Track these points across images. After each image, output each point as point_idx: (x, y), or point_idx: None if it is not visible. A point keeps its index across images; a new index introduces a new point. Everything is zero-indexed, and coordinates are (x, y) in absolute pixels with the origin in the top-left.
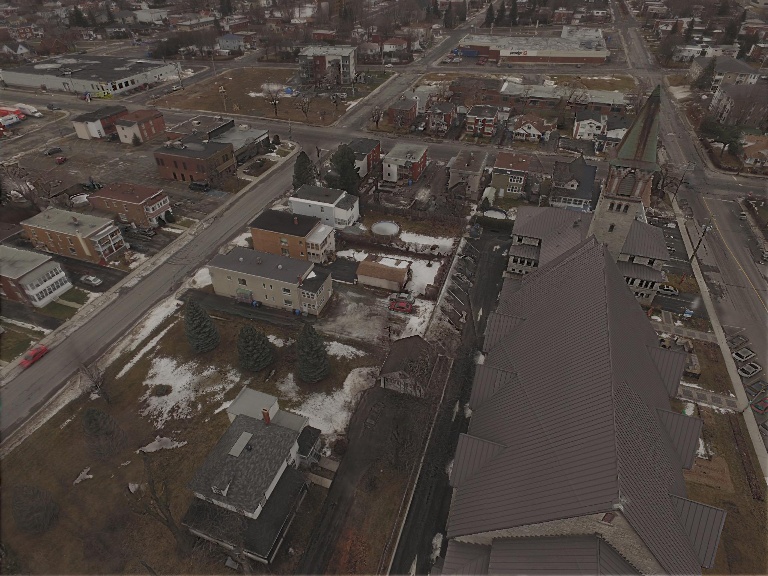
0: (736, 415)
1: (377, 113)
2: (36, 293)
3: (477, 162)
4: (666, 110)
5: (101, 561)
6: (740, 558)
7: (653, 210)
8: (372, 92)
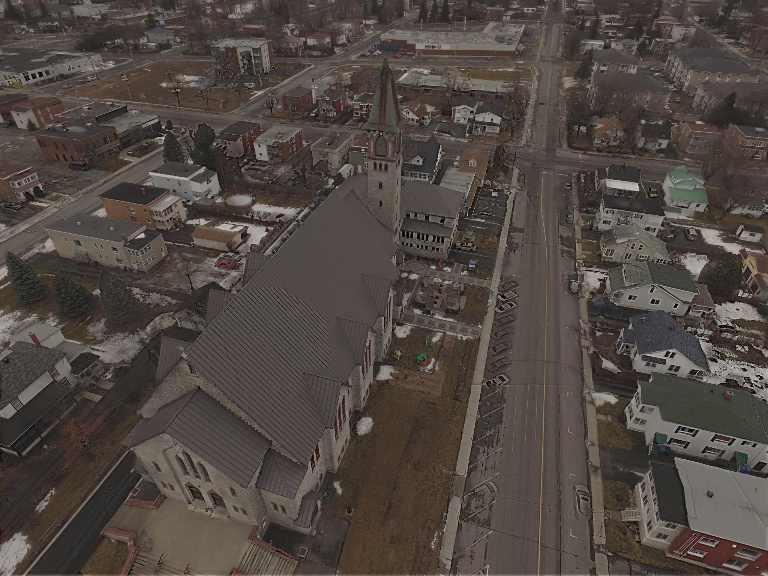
0: (474, 341)
1: (271, 100)
2: None
3: (339, 142)
4: (528, 95)
5: None
6: (418, 441)
7: (491, 183)
8: (282, 82)
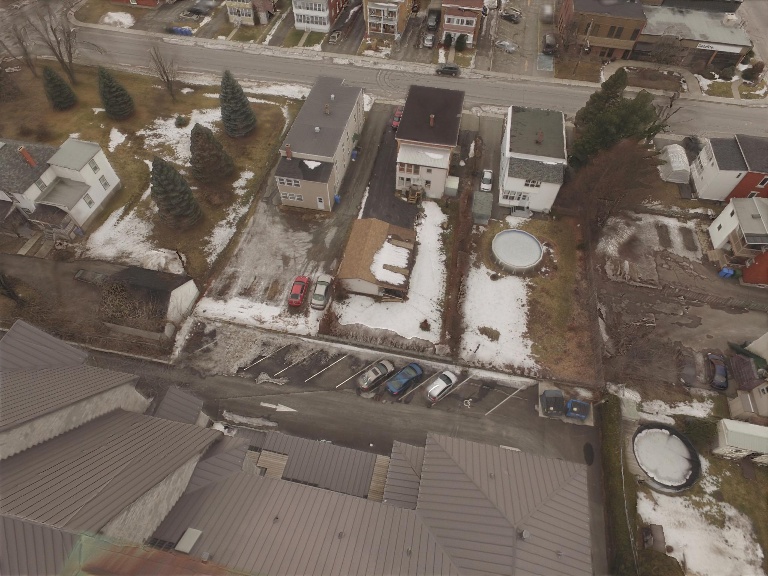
0: None
1: None
2: (297, 13)
3: None
4: None
5: (15, 139)
6: None
7: None
8: None
